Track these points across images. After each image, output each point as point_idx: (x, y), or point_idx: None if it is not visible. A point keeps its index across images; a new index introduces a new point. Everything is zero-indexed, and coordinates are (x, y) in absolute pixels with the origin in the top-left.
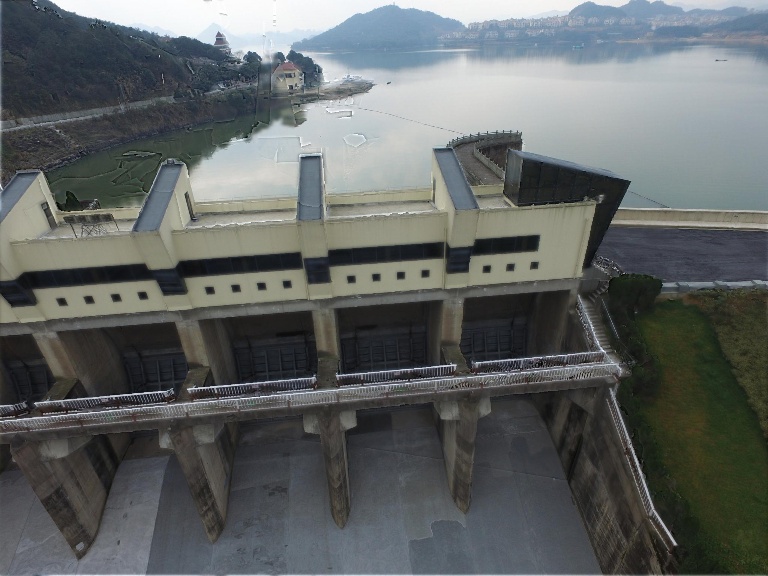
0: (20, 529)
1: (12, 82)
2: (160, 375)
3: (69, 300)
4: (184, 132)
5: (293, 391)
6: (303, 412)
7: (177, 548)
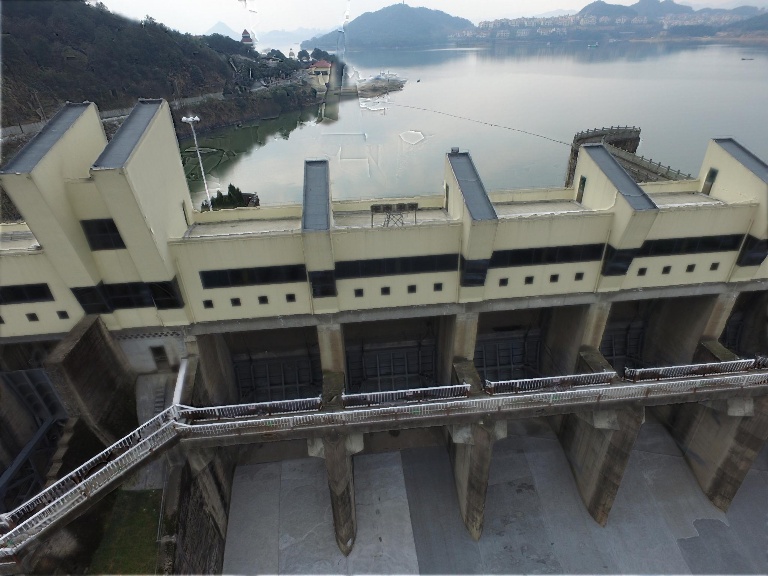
0: (276, 525)
1: (75, 78)
2: (379, 370)
3: (366, 291)
4: (233, 129)
5: (590, 386)
6: (609, 407)
7: (442, 545)
